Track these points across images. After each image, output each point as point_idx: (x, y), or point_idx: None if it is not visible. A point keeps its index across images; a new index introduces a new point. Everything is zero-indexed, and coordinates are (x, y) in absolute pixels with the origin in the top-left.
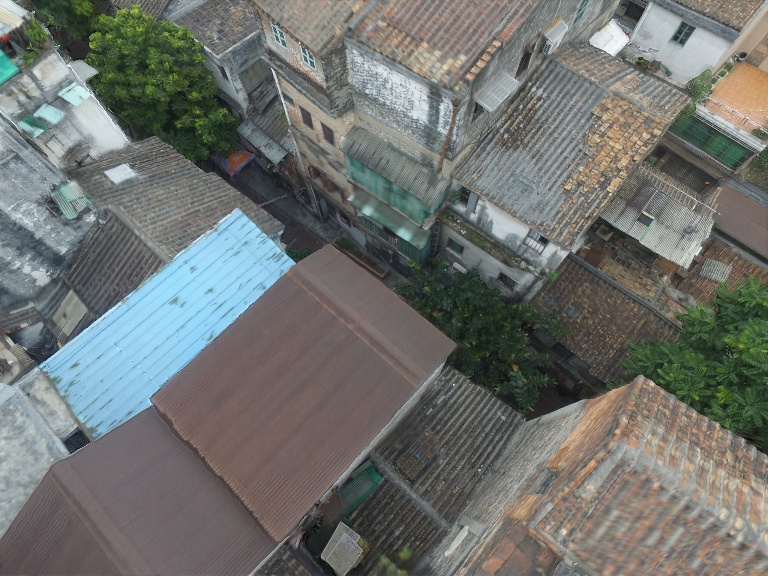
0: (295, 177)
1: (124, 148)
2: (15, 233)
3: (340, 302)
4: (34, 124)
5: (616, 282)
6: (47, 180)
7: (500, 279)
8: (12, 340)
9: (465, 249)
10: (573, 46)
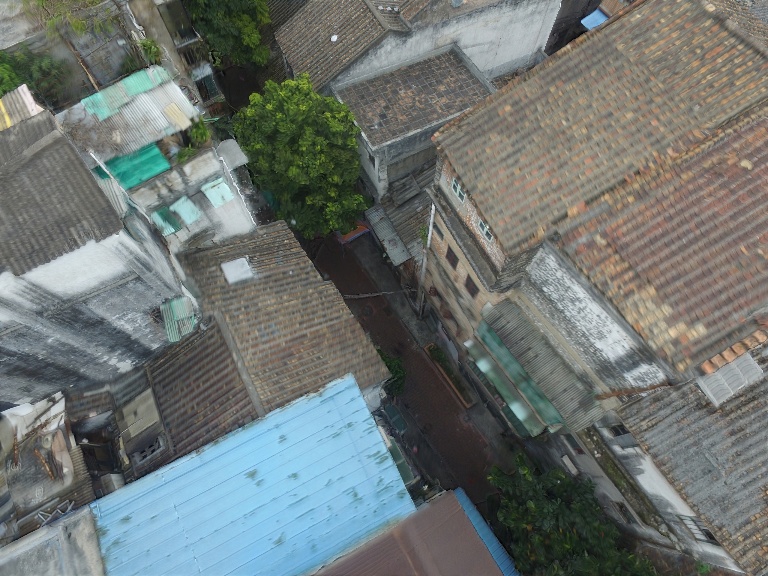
0: (409, 274)
1: (249, 233)
2: (112, 335)
3: None
4: (167, 219)
5: None
6: (161, 295)
7: (618, 504)
8: (75, 439)
9: (586, 456)
10: None
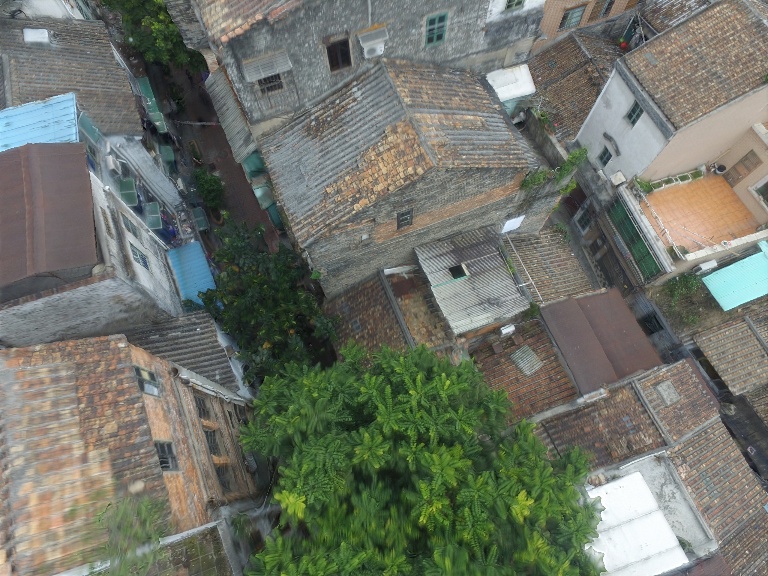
0: None
1: (62, 19)
2: None
3: (38, 186)
4: None
5: (401, 317)
6: None
7: None
8: None
9: None
10: (439, 68)
